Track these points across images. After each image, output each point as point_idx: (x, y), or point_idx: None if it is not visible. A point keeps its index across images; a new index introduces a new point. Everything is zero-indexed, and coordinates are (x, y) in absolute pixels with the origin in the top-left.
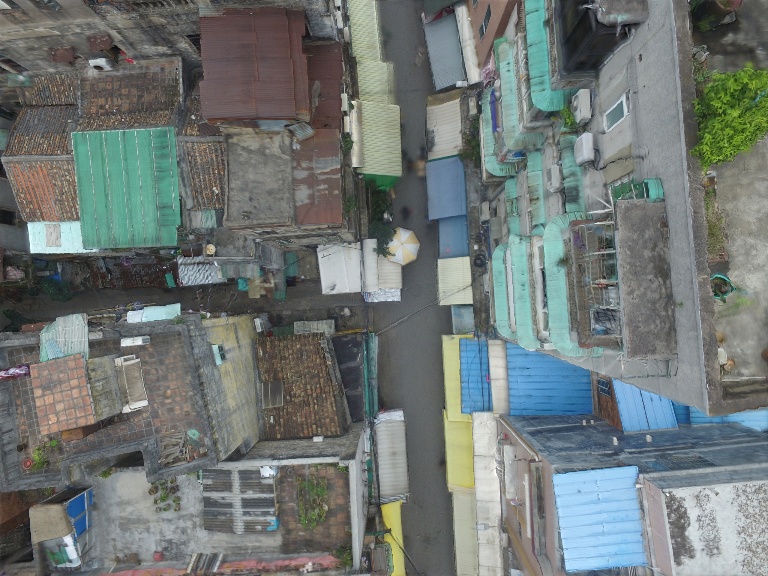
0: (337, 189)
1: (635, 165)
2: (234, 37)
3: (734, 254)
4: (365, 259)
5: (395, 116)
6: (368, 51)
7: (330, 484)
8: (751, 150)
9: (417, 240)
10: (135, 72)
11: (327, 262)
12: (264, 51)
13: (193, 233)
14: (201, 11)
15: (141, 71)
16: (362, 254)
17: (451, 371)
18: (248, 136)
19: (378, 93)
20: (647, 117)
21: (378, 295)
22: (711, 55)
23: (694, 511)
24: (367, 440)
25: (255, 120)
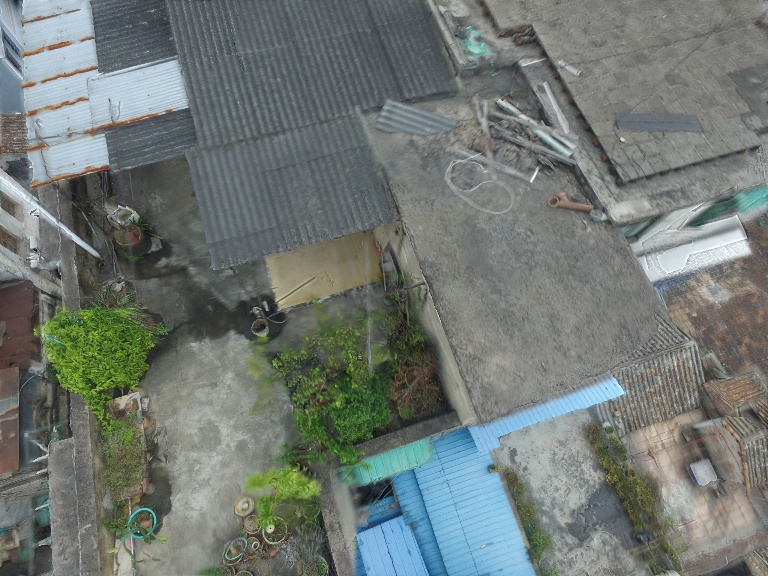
0: (13, 432)
1: None
2: None
3: (175, 474)
4: None
5: None
6: None
7: None
8: (188, 359)
9: None
10: None
11: None
12: None
13: None
14: None
15: None
16: None
17: None
18: None
19: None
20: None
21: None
22: (146, 279)
23: None
24: None
25: None
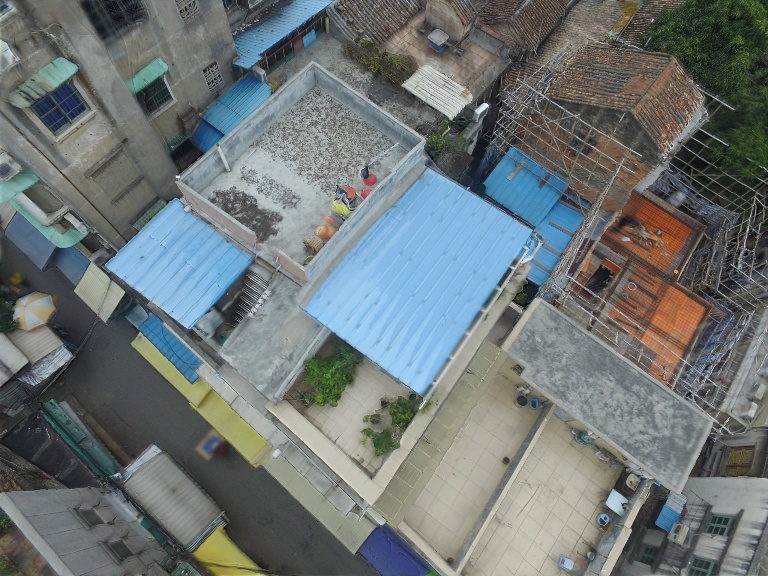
0: None
1: None
2: None
3: None
4: None
5: None
6: None
7: (17, 556)
8: None
9: (45, 294)
10: None
11: None
12: None
13: None
14: None
15: None
16: None
17: (162, 364)
18: None
19: None
20: None
21: (44, 370)
22: None
23: (251, 189)
24: (125, 503)
25: None
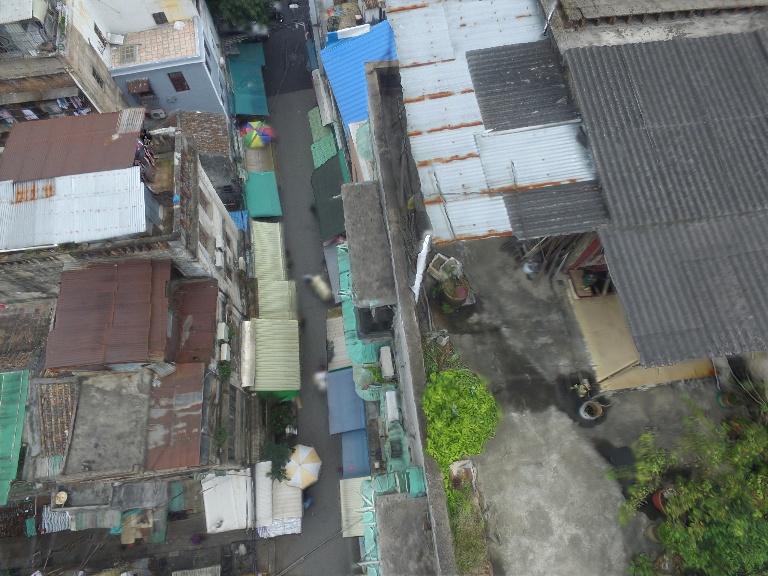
0: (196, 427)
1: (409, 443)
2: (94, 287)
3: (509, 560)
4: (257, 486)
5: (293, 330)
6: (271, 271)
7: None
8: (511, 430)
9: (318, 458)
10: (8, 314)
11: (213, 494)
12: (123, 298)
13: (39, 482)
14: (65, 265)
15: (14, 313)
16: (251, 482)
17: None
18: (105, 376)
19: (279, 309)
20: (410, 395)
21: (275, 528)
22: (459, 334)
23: None
24: None
25: (103, 365)
